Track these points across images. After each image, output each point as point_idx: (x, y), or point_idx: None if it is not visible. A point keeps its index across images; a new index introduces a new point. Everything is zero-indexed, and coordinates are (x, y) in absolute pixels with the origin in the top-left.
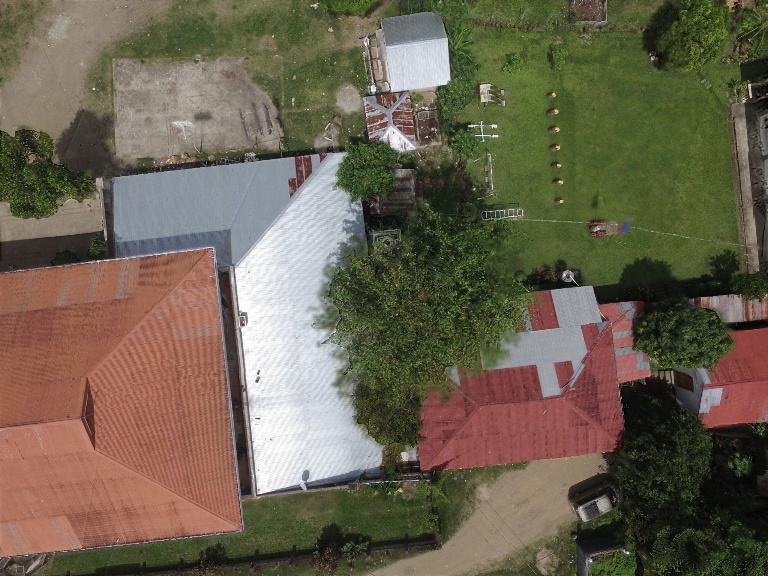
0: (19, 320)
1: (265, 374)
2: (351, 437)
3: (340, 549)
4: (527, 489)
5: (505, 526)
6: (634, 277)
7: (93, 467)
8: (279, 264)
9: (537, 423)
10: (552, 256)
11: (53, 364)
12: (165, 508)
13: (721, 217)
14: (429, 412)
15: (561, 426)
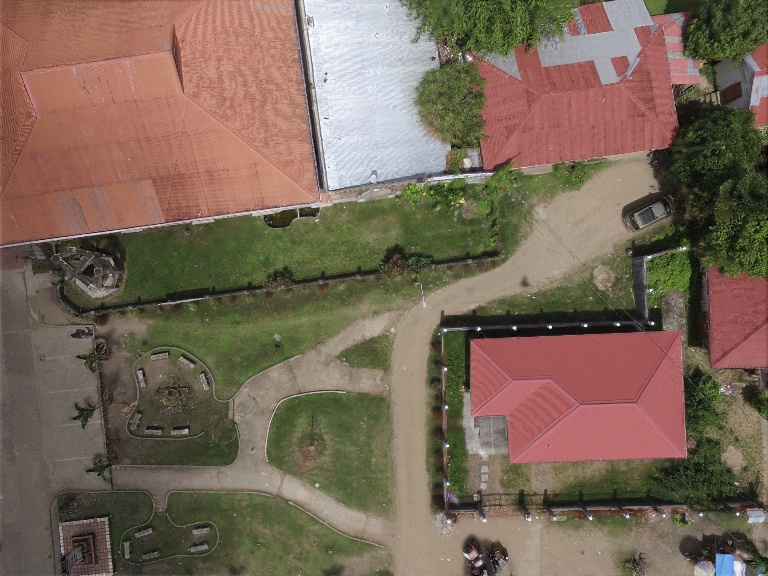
0: None
1: (332, 77)
2: (416, 141)
3: None
4: (582, 209)
5: None
6: (678, 8)
7: (181, 116)
8: None
9: (596, 114)
10: None
11: (139, 18)
12: (247, 171)
13: None
14: (491, 110)
15: (619, 117)
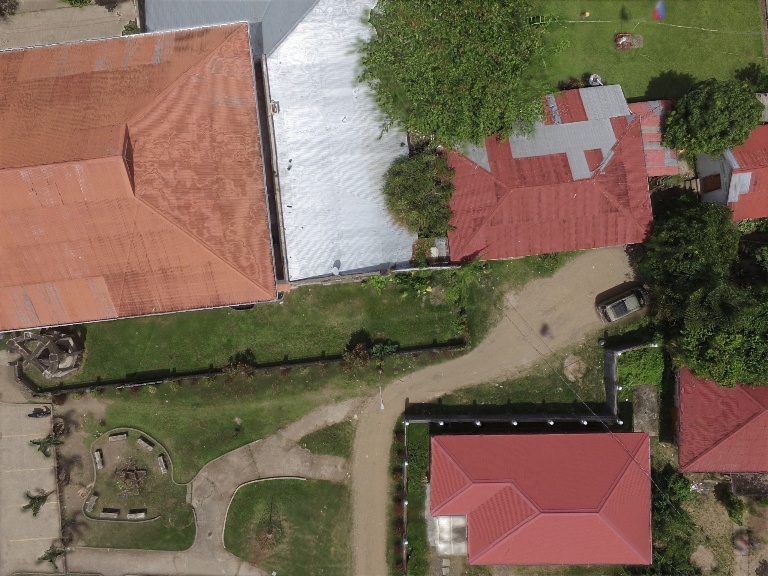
0: (56, 83)
1: (297, 163)
2: (381, 229)
3: (369, 350)
4: (554, 297)
5: (532, 333)
6: (660, 90)
7: (132, 217)
8: (310, 55)
9: (567, 208)
10: (578, 69)
11: (92, 115)
12: (201, 270)
13: (746, 31)
14: (459, 201)
15: (591, 212)
